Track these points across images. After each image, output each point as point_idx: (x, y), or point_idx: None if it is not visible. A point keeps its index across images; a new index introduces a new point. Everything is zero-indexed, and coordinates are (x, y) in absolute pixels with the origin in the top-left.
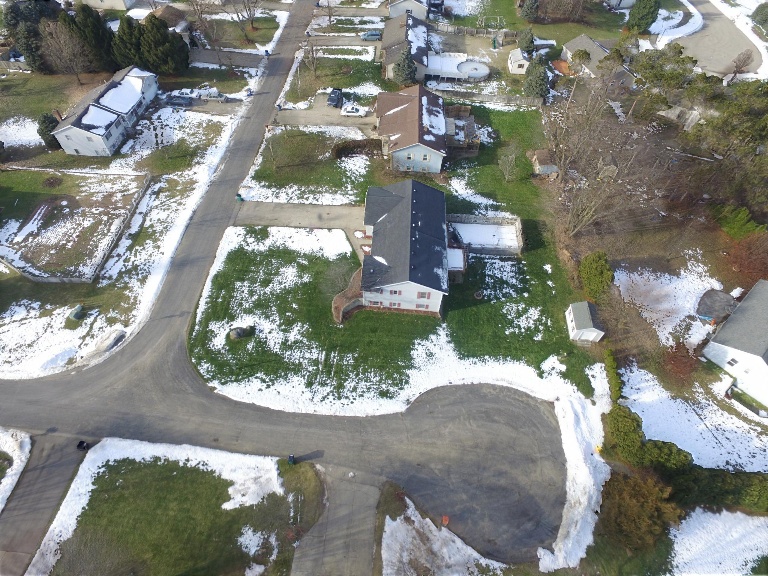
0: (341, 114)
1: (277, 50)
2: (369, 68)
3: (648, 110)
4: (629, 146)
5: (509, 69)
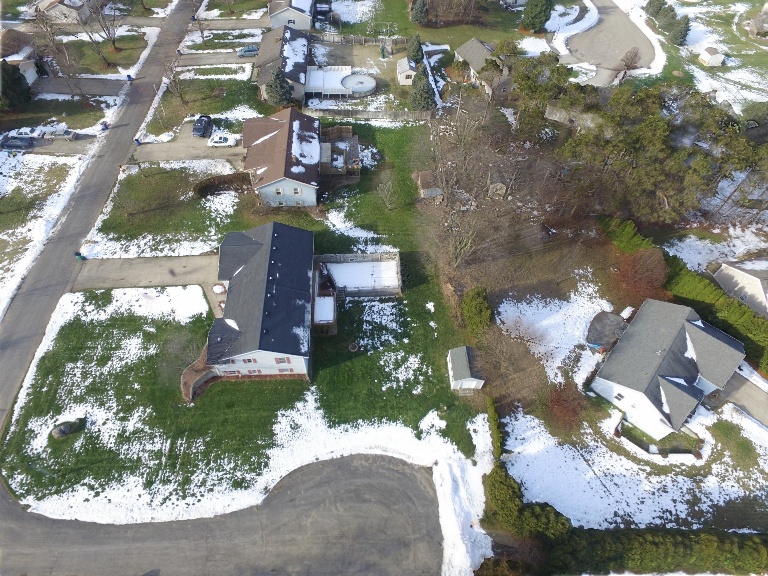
0: (208, 145)
1: (142, 73)
2: (244, 89)
3: (526, 125)
4: (521, 157)
5: (398, 80)
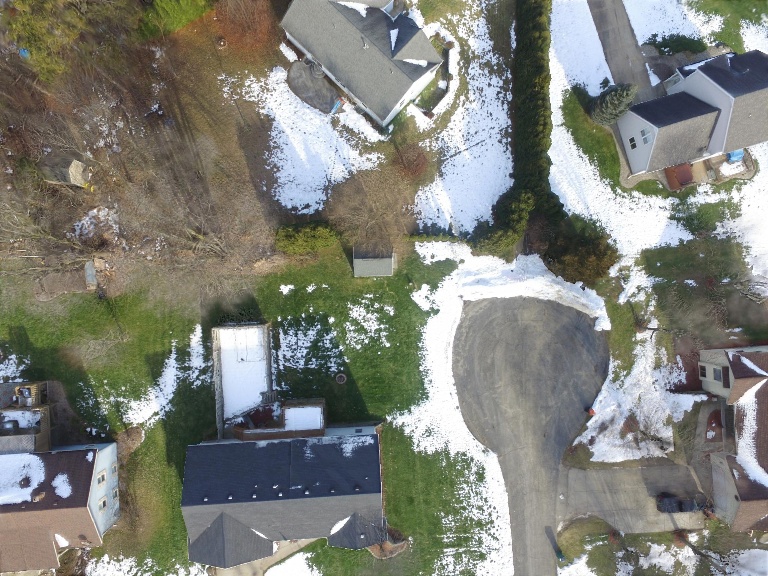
0: None
1: None
2: None
3: None
4: None
5: None
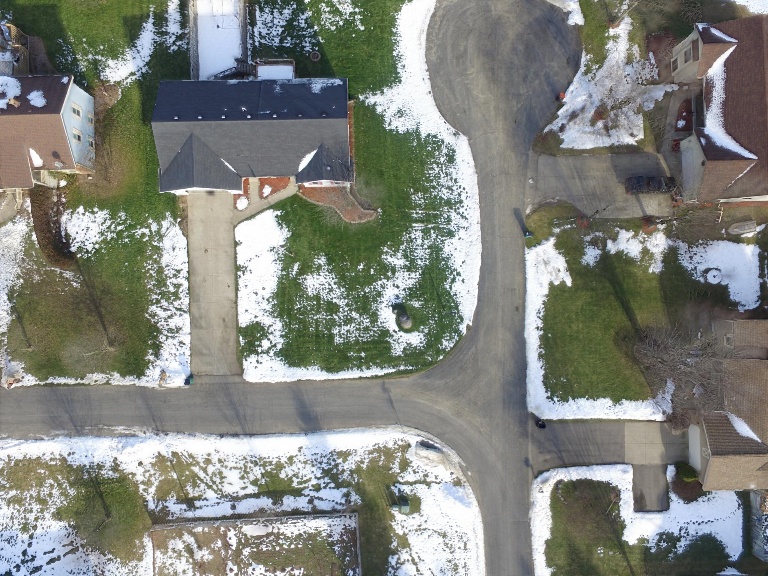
0: None
1: None
2: None
3: None
4: None
5: None
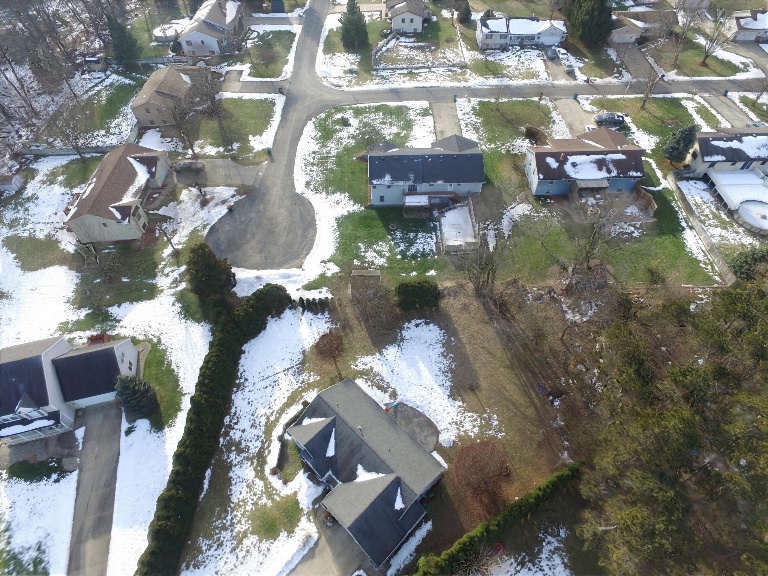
0: (585, 126)
1: (676, 82)
2: None
3: None
4: None
5: None
